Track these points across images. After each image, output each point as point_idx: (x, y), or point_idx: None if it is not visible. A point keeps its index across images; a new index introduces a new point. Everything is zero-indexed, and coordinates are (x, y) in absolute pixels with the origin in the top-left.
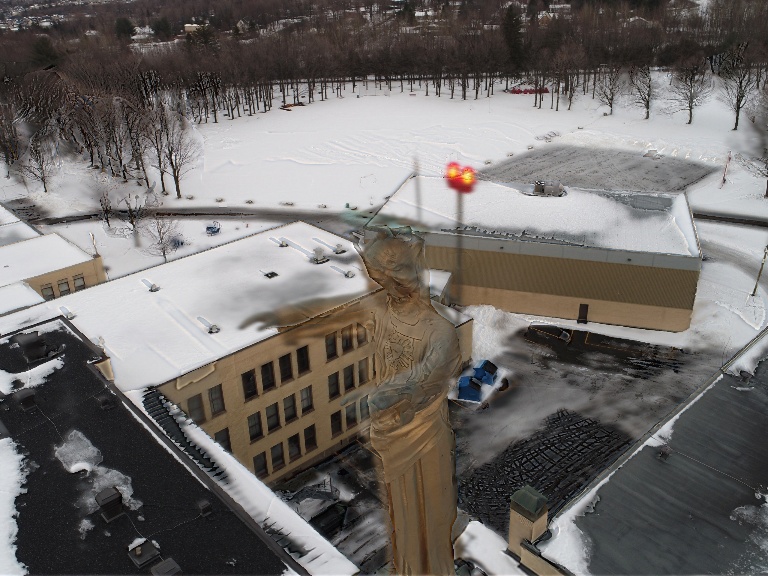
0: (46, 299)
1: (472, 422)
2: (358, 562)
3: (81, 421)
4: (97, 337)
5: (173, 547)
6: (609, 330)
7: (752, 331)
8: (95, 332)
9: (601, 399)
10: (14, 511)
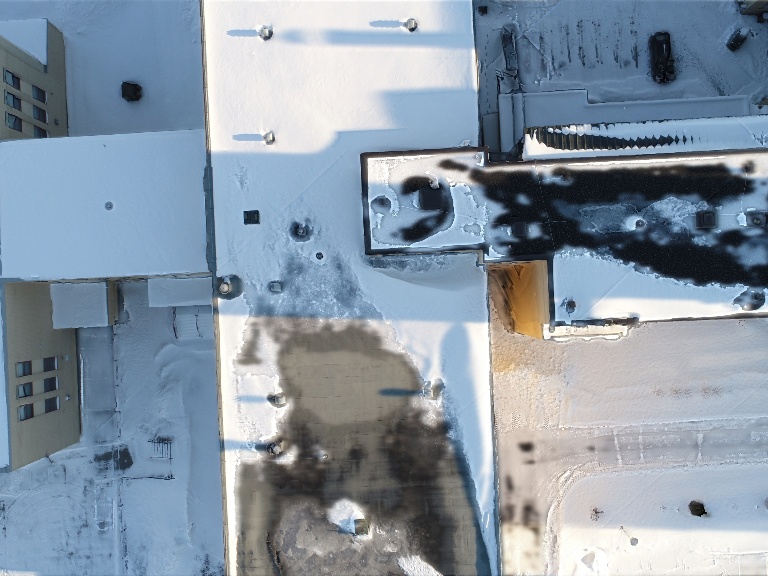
0: (16, 129)
1: None
2: (581, 66)
3: (571, 202)
4: (339, 131)
5: (761, 202)
6: None
7: None
8: (327, 128)
9: None
10: (652, 276)
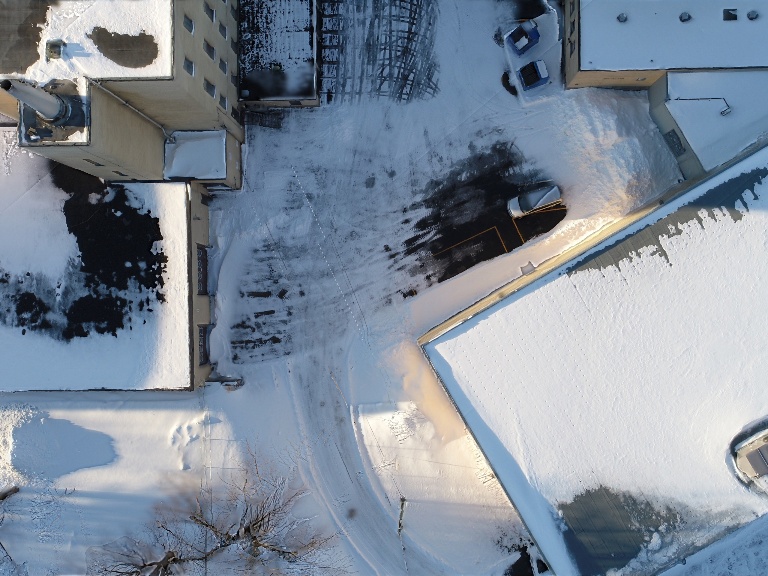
0: None
1: (489, 7)
2: None
3: None
4: None
5: None
6: (492, 274)
7: (362, 394)
8: None
9: (418, 138)
10: None
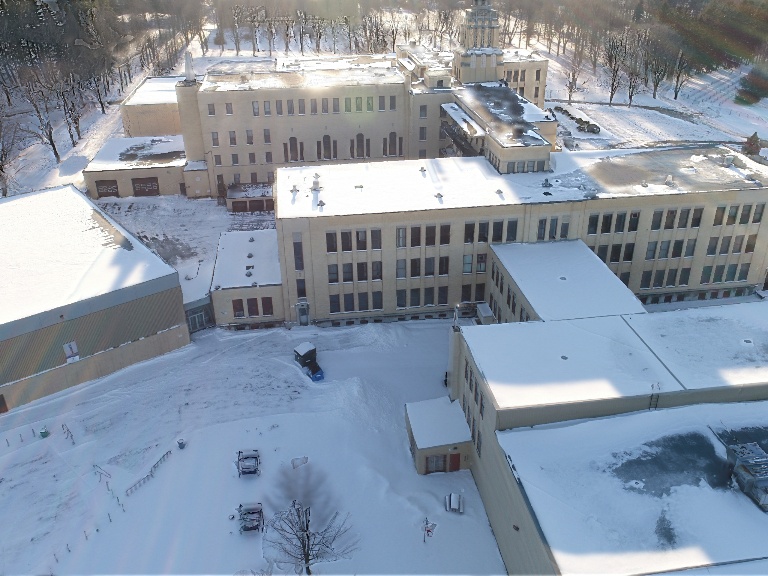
0: None
1: None
2: None
3: None
4: None
5: None
6: None
7: None
8: None
9: (205, 234)
10: None
